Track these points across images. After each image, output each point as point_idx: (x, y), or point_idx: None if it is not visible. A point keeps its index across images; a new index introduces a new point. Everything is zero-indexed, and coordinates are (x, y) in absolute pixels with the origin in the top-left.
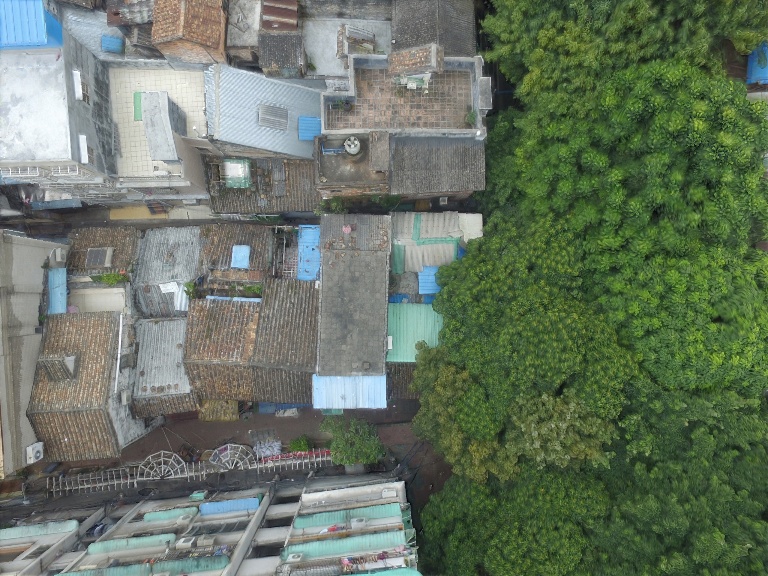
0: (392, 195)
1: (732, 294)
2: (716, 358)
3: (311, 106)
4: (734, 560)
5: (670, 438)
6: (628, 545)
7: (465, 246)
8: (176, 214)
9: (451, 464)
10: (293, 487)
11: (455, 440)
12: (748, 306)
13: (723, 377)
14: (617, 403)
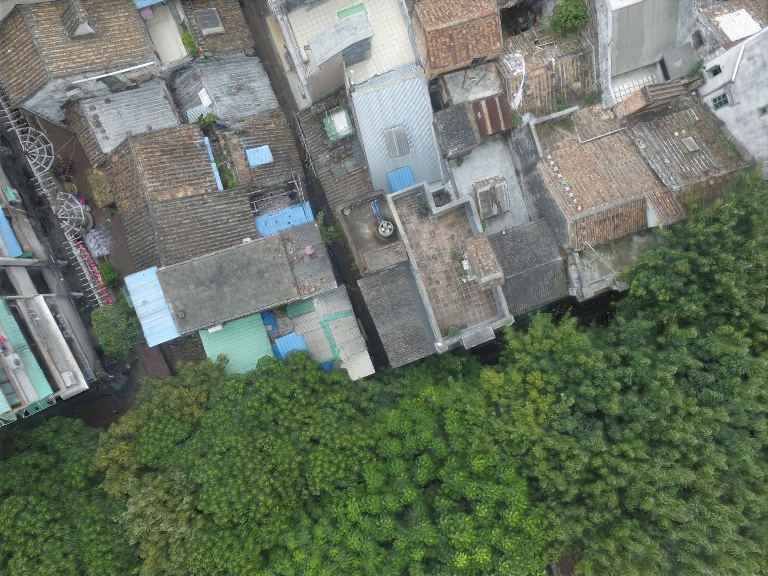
0: None
1: None
2: None
3: (425, 174)
4: None
5: None
6: None
7: (336, 367)
8: (292, 78)
9: None
10: None
11: (125, 427)
12: None
13: None
14: (207, 570)
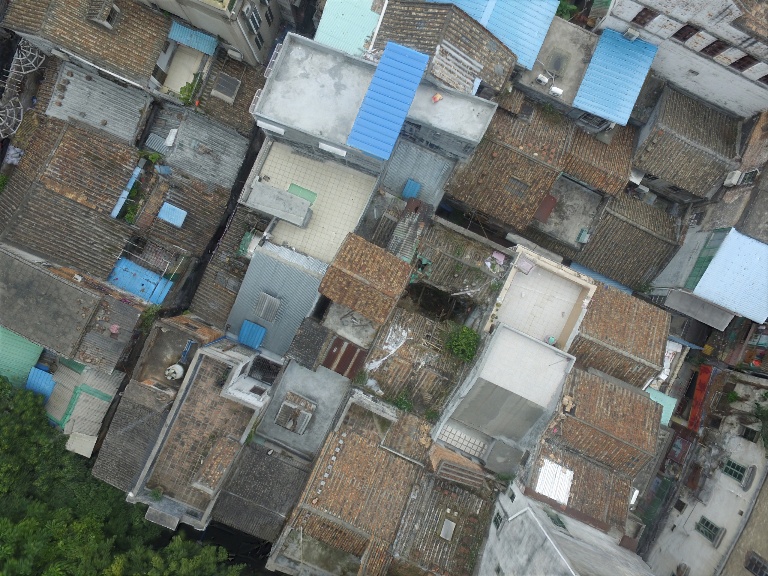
0: None
1: None
2: None
3: (276, 344)
4: None
5: None
6: None
7: (58, 429)
8: None
9: None
10: None
11: None
12: None
13: None
14: None
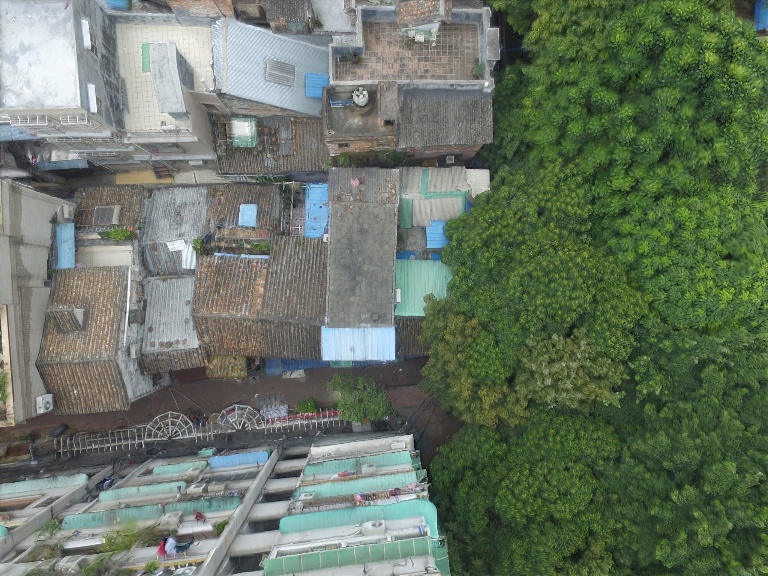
0: (399, 151)
1: (741, 231)
2: (726, 293)
3: (318, 64)
4: (745, 490)
5: (679, 380)
6: (638, 484)
7: (473, 201)
8: (182, 178)
9: (459, 418)
10: (301, 446)
11: (465, 385)
12: (758, 242)
13: (732, 315)
14: (627, 344)
